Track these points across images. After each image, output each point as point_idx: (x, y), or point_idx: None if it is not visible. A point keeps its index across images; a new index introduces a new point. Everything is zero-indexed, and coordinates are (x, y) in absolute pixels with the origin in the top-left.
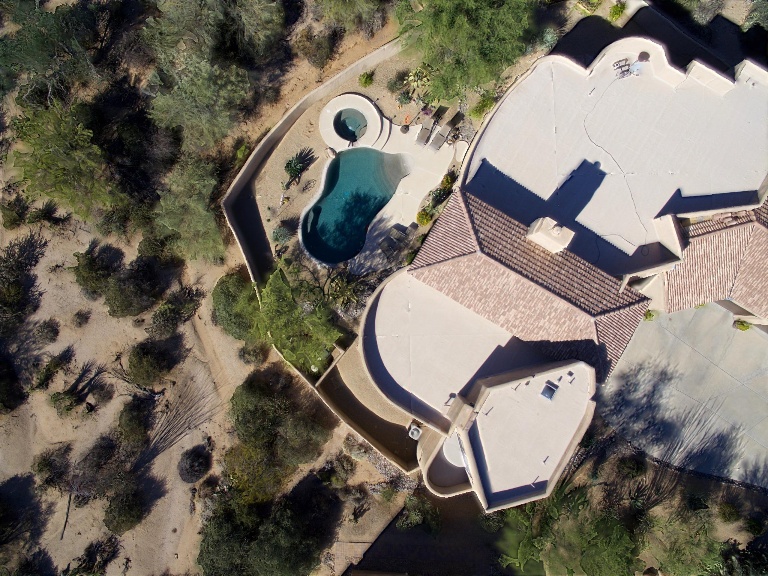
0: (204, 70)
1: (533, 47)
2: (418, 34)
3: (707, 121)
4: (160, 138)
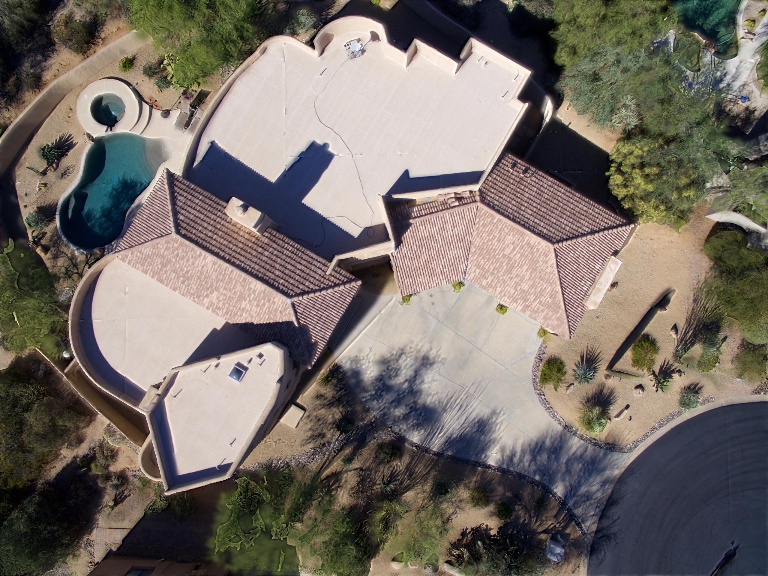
0: None
1: (292, 29)
2: None
3: (438, 101)
4: None
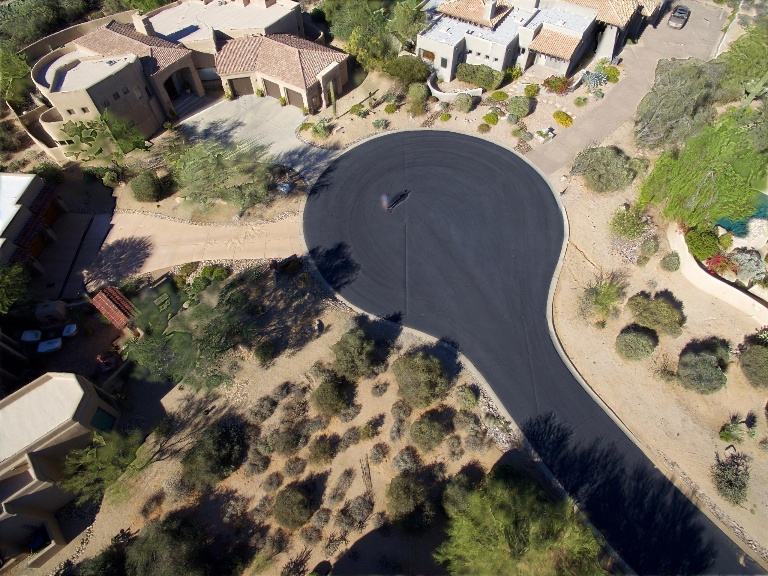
0: (28, 3)
1: None
2: None
3: None
4: None
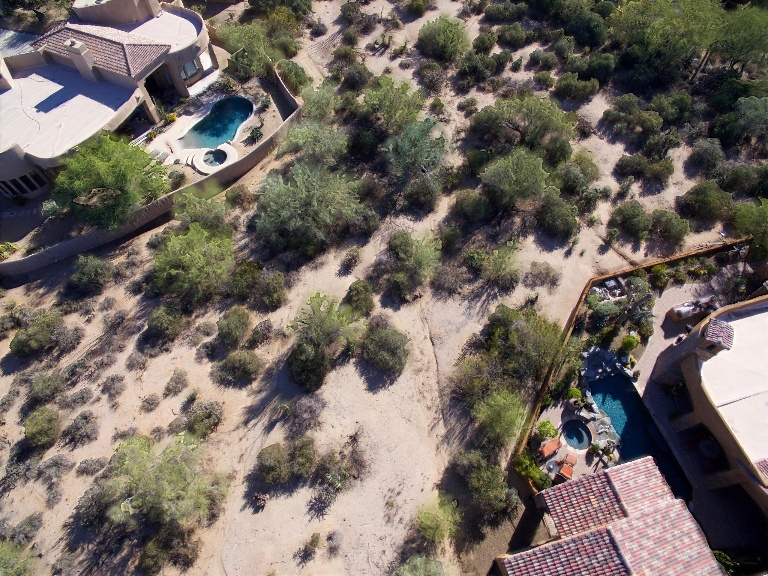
0: (301, 137)
1: None
2: None
3: None
4: None
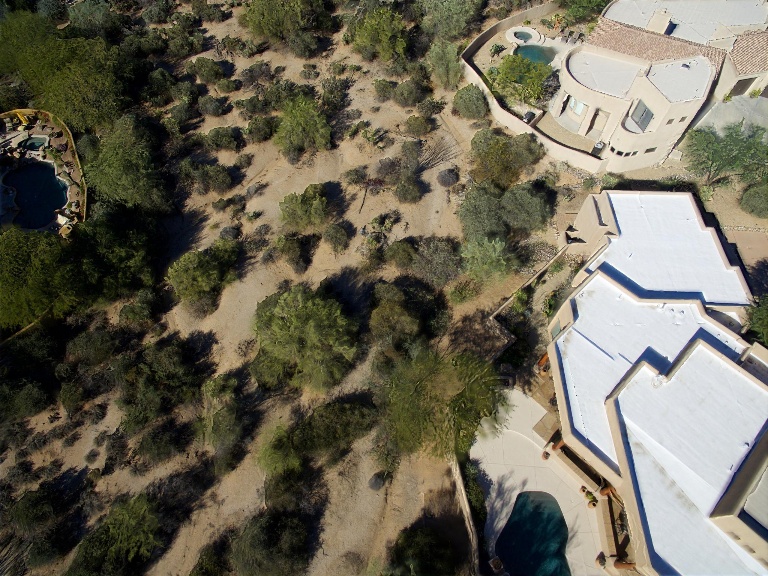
0: None
1: None
2: (552, 6)
3: (723, 8)
4: None
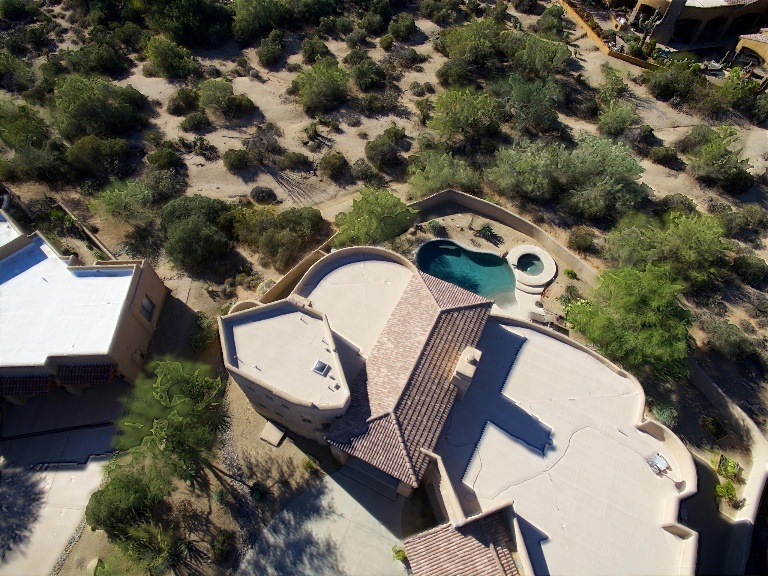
0: (538, 162)
1: (654, 404)
2: None
3: (639, 572)
4: (488, 159)
